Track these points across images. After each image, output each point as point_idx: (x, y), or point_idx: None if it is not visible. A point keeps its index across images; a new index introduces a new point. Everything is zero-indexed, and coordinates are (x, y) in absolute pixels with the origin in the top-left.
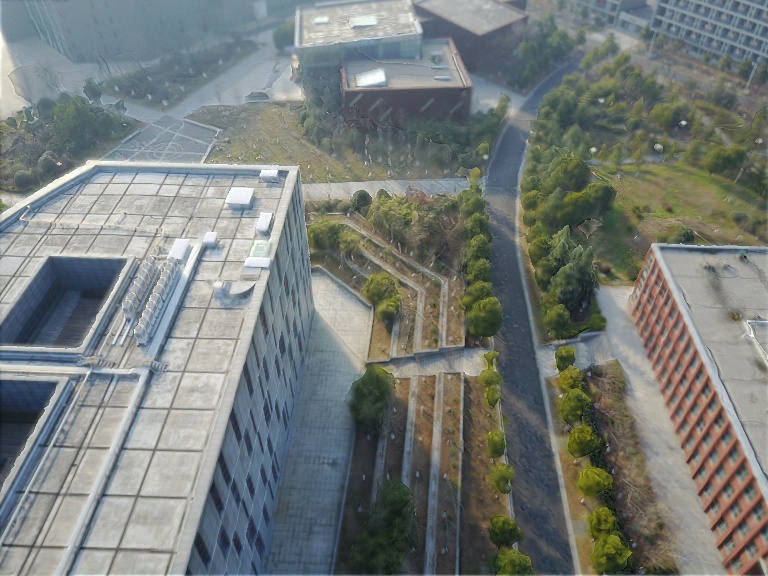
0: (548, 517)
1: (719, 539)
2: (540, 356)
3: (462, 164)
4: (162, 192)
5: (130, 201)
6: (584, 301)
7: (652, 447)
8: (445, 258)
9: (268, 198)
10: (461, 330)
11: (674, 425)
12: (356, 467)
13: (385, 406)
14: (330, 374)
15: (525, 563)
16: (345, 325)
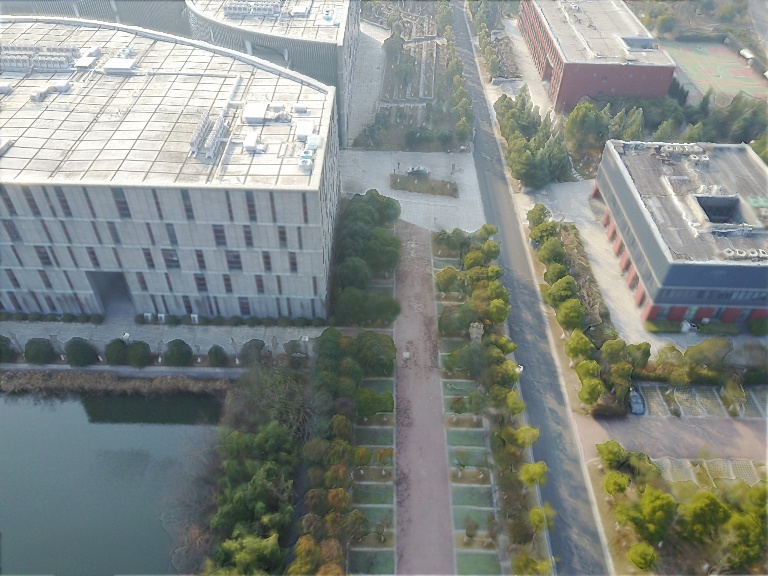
0: (472, 73)
1: (539, 70)
2: (473, 40)
3: None
4: None
5: None
6: (495, 23)
7: (519, 56)
8: (426, 10)
9: None
10: (435, 31)
11: (529, 51)
12: (388, 66)
13: (400, 46)
14: (372, 48)
15: (459, 59)
16: (377, 36)
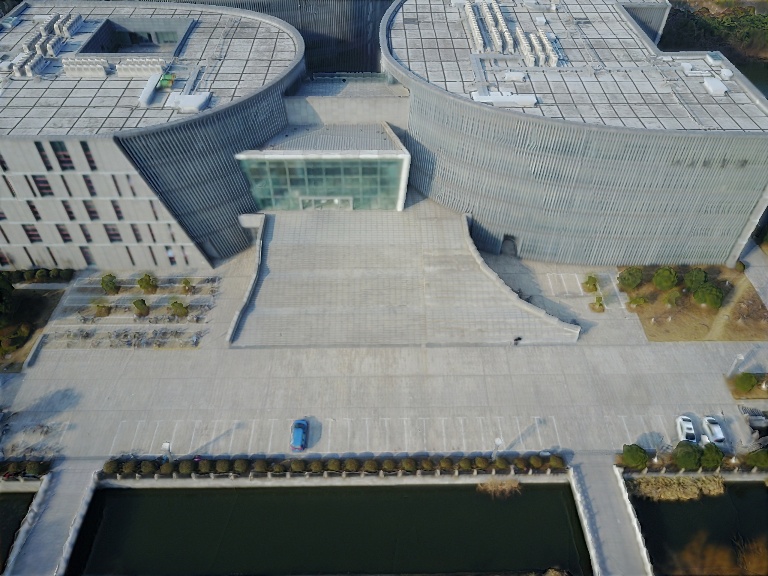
0: None
1: None
2: None
3: (17, 0)
4: None
5: None
6: None
7: None
8: None
9: None
10: None
11: None
12: None
13: None
14: None
15: None
16: None
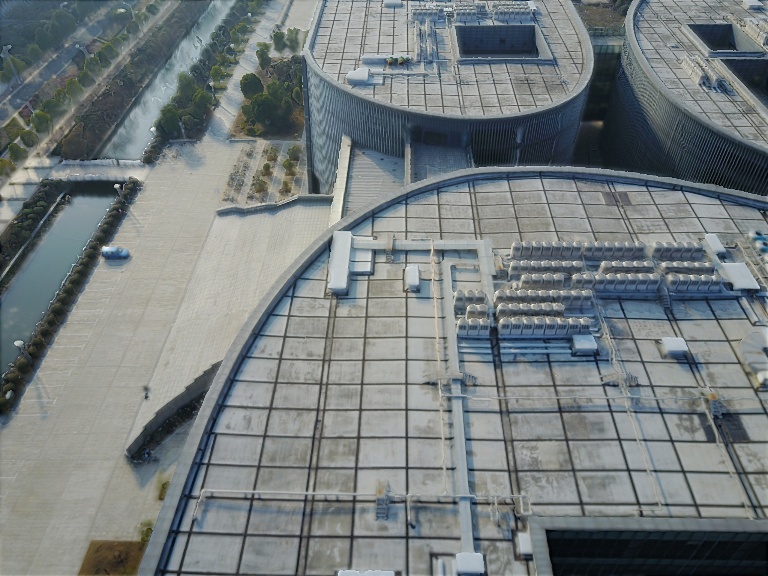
0: None
1: None
2: None
3: None
4: (699, 4)
5: (687, 8)
6: None
7: None
8: None
9: (766, 5)
10: None
11: None
12: None
13: None
14: None
15: None
16: None
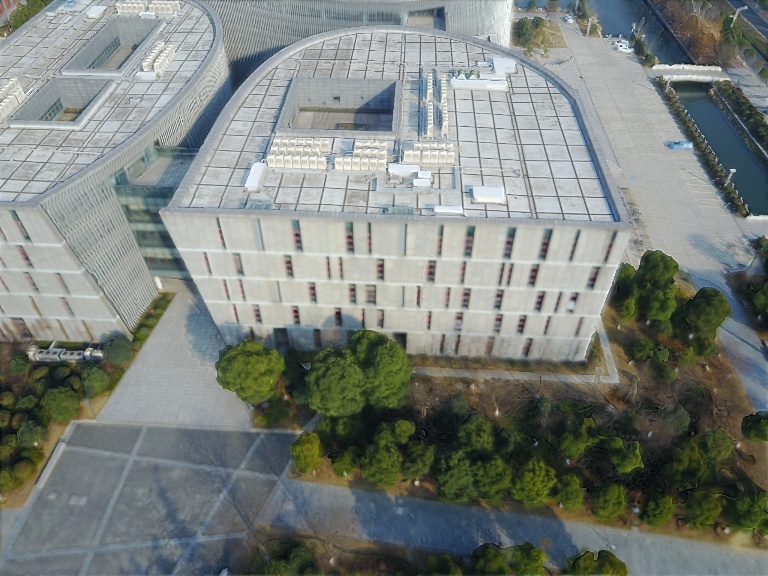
0: None
1: None
2: None
3: None
4: None
5: (3, 172)
6: None
7: None
8: None
9: None
10: None
11: None
12: None
13: None
14: None
15: None
16: None
